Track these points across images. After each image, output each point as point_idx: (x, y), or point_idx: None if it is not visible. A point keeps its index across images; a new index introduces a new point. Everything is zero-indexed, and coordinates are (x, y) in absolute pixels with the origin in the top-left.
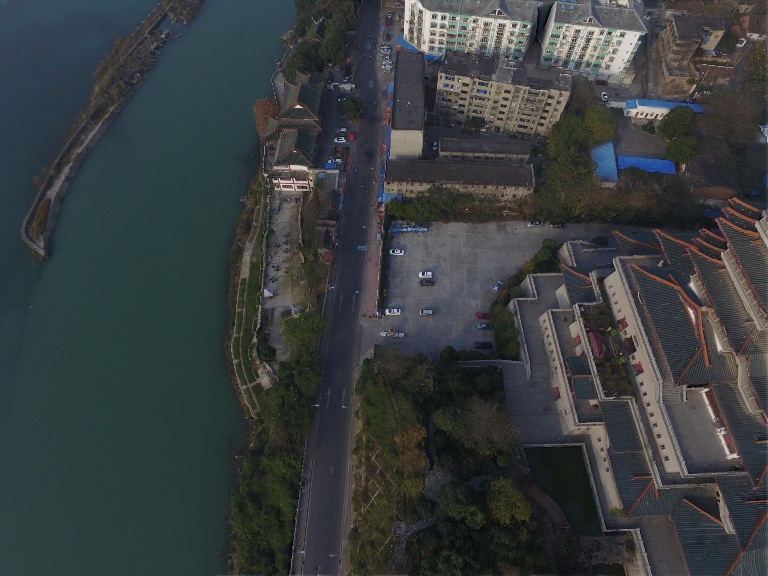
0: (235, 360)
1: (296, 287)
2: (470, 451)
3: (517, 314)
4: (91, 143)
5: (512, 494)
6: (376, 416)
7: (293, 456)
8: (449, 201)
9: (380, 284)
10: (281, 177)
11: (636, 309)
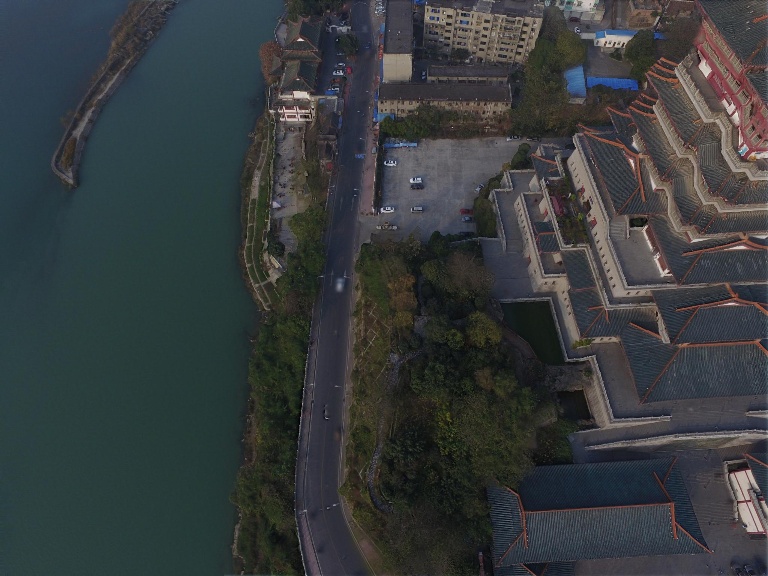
0: (248, 264)
1: (301, 200)
2: (452, 297)
3: (495, 202)
4: (110, 91)
5: (486, 321)
6: (373, 282)
7: (302, 317)
8: (436, 117)
9: (375, 187)
10: (286, 105)
11: (590, 170)
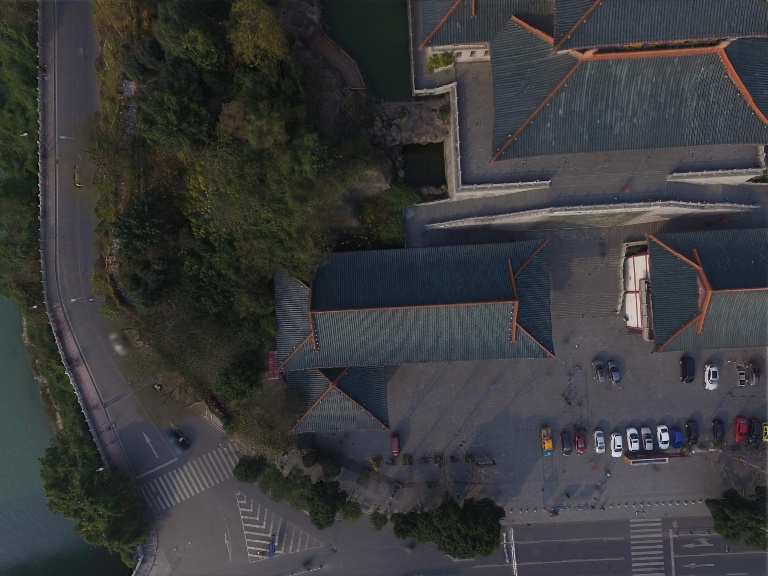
0: None
1: None
2: None
3: None
4: None
5: (255, 14)
6: None
7: (6, 21)
8: None
9: None
10: None
11: None
